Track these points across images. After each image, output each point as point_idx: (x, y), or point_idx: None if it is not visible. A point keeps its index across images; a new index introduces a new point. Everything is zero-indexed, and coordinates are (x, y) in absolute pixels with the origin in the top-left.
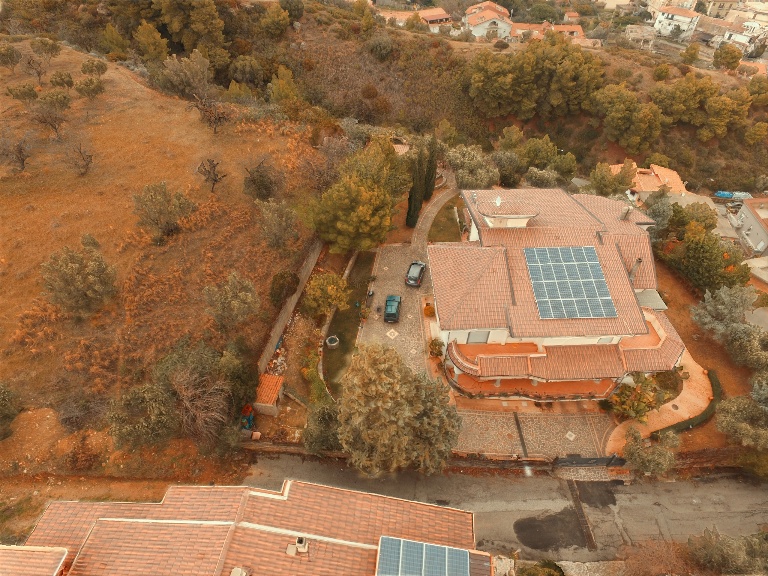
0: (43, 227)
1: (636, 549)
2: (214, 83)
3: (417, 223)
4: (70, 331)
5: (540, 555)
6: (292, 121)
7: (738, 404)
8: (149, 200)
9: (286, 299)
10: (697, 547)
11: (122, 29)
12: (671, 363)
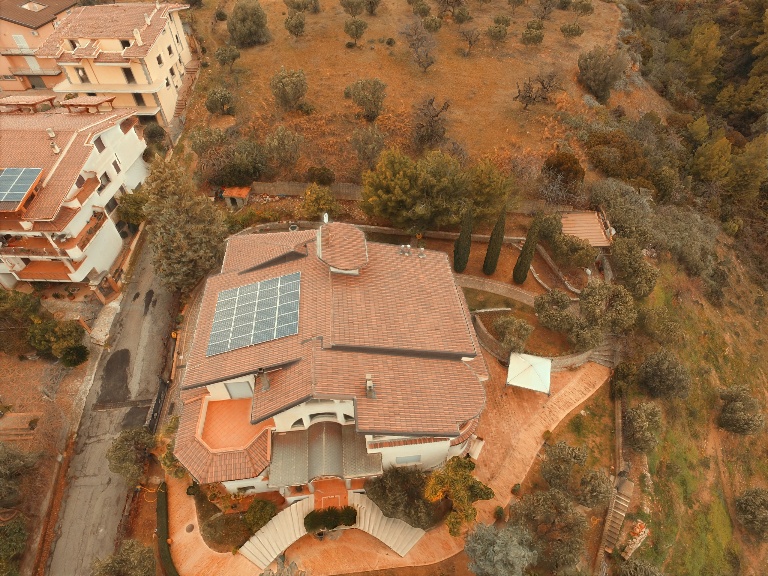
0: (363, 76)
1: (81, 446)
2: (735, 122)
3: (467, 275)
4: (281, 111)
5: (102, 365)
6: (585, 146)
7: (136, 567)
8: (358, 83)
9: (308, 181)
10: (32, 454)
11: (739, 35)
12: (180, 454)
